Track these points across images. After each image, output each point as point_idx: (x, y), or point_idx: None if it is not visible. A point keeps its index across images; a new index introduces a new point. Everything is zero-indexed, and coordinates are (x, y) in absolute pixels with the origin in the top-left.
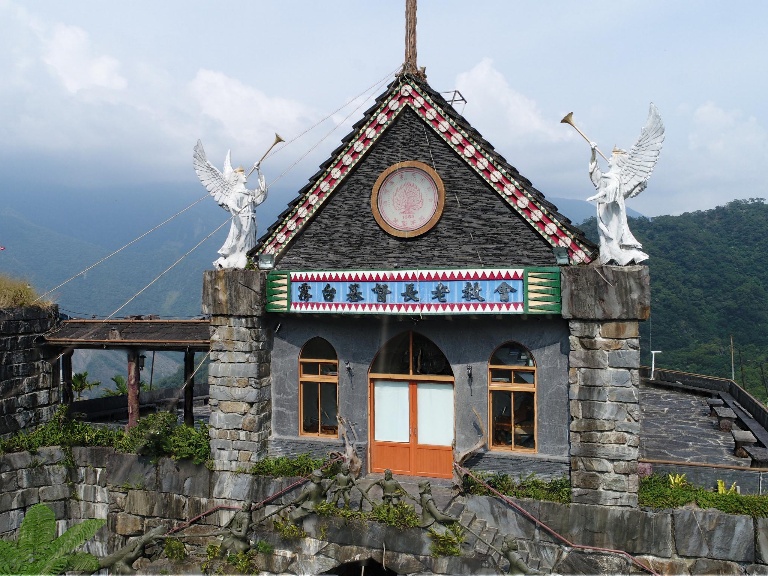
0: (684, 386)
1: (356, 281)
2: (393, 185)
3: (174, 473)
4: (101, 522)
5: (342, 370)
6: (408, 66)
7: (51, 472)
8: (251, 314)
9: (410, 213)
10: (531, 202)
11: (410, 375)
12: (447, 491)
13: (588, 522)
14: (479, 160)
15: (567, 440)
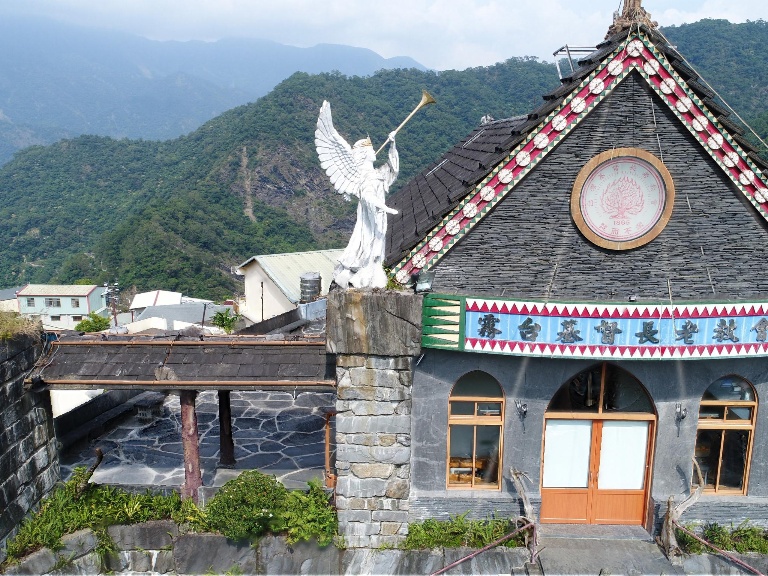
0: None
1: (573, 316)
2: (603, 179)
3: (285, 555)
4: None
5: (511, 411)
6: None
7: (81, 566)
8: (405, 353)
9: (624, 218)
10: None
11: (599, 414)
12: (652, 548)
13: None
14: (728, 154)
15: None
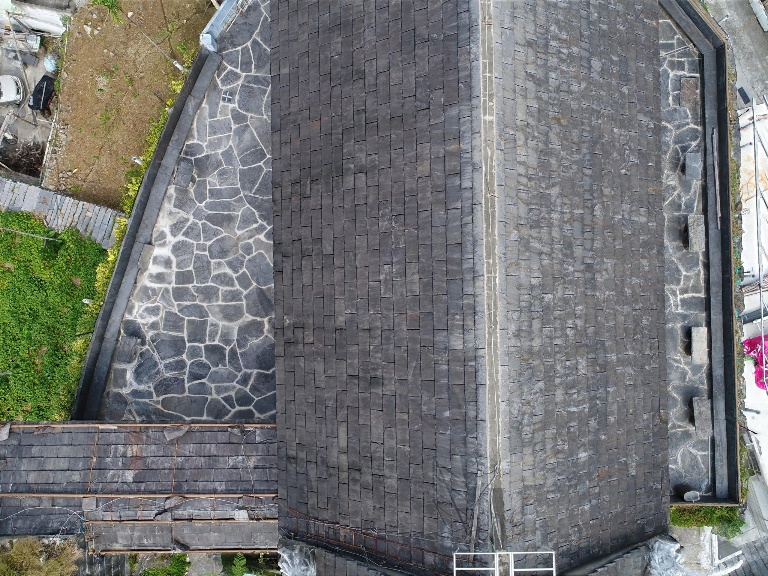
0: (668, 8)
1: None
2: None
3: None
4: None
5: None
6: None
7: None
8: None
9: None
10: None
11: None
12: None
13: None
14: None
15: None
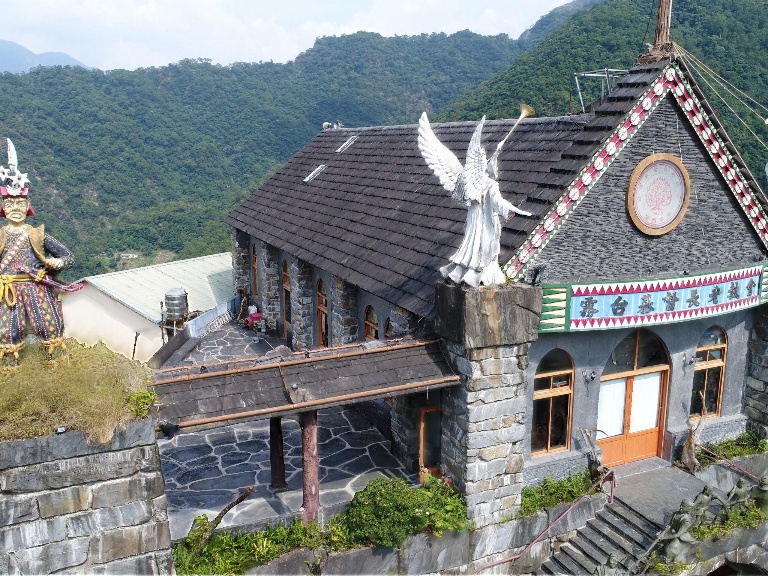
0: None
1: (650, 291)
2: (648, 179)
3: (425, 551)
4: None
5: (579, 379)
6: None
7: None
8: (528, 340)
9: (660, 209)
10: (752, 199)
11: (635, 371)
12: (677, 471)
13: None
14: (722, 157)
15: (741, 400)
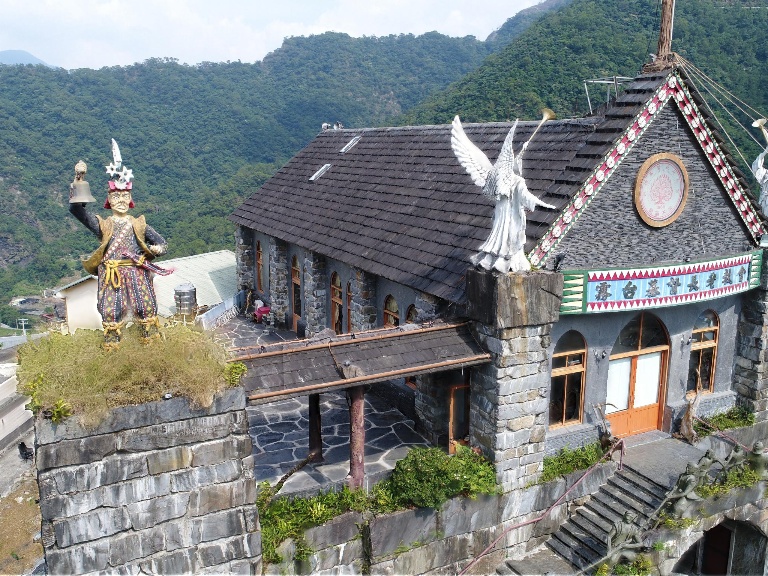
0: None
1: (656, 277)
2: (652, 176)
3: (460, 513)
4: None
5: (591, 358)
6: None
7: None
8: (550, 321)
9: (663, 203)
10: (742, 195)
11: (639, 351)
12: (676, 442)
13: (761, 434)
14: (716, 157)
15: (731, 378)
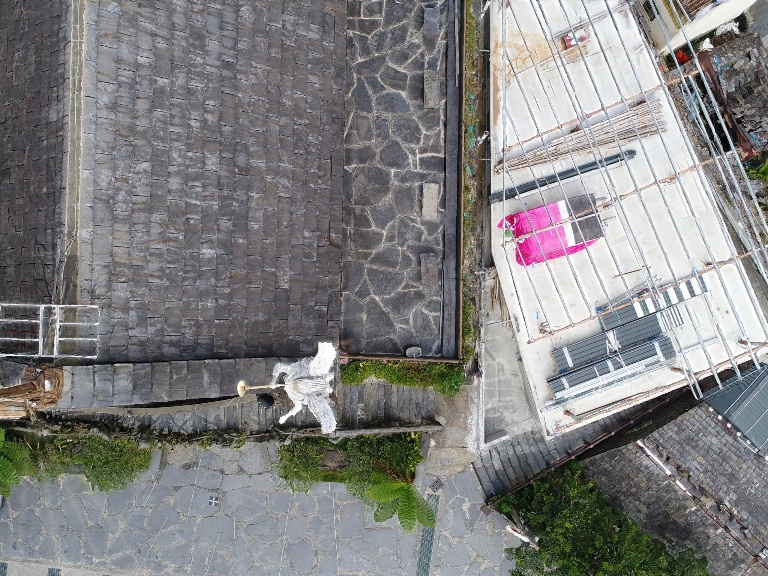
0: None
1: None
2: None
3: None
4: (1, 433)
5: None
6: (35, 406)
7: None
8: None
9: None
10: None
11: None
12: None
13: None
14: None
15: None
